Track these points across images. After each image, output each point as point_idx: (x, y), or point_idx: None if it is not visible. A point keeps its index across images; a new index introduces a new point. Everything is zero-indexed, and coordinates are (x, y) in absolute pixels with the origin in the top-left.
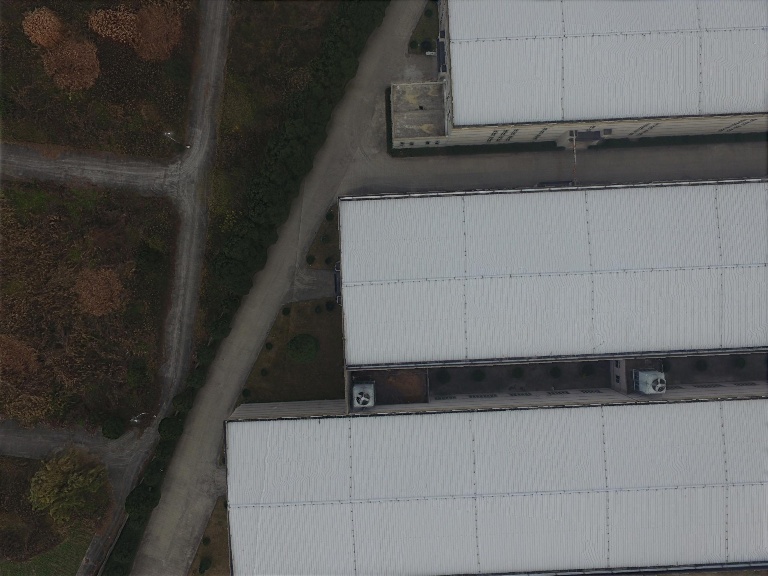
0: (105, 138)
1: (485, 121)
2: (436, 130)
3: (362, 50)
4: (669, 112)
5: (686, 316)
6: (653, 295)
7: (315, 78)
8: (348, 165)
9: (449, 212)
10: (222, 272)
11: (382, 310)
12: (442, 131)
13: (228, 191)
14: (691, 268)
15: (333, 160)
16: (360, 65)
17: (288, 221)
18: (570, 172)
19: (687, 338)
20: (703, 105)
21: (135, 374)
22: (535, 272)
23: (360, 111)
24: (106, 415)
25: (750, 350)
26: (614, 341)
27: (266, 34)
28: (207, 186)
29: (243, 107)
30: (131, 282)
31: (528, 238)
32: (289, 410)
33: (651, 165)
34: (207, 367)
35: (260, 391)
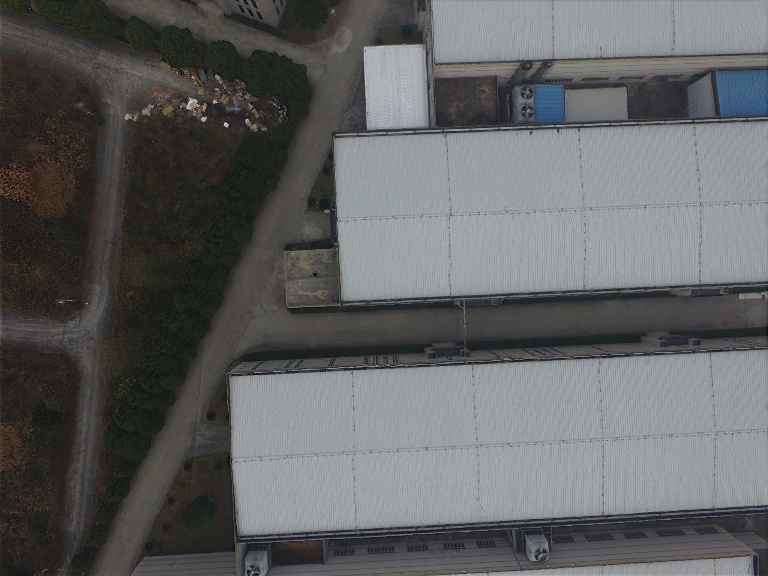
0: (1, 296)
1: (374, 297)
2: (330, 296)
3: (261, 207)
4: (554, 287)
5: (567, 489)
6: (535, 470)
7: (207, 248)
8: (248, 322)
9: (338, 387)
10: (114, 445)
11: (272, 484)
12: (336, 297)
13: (122, 358)
14: (573, 441)
15: (233, 317)
16: (259, 222)
17: (188, 377)
18: (468, 328)
19: (568, 509)
20: (591, 275)
21: (35, 533)
22: (422, 446)
23: (259, 268)
24: (8, 571)
25: (631, 517)
26: (496, 516)
27: (163, 191)
28: (106, 343)
29: (142, 263)
30: (30, 441)
31: (416, 413)
32: (186, 573)
33: (547, 321)
34: (109, 522)
35: (163, 544)
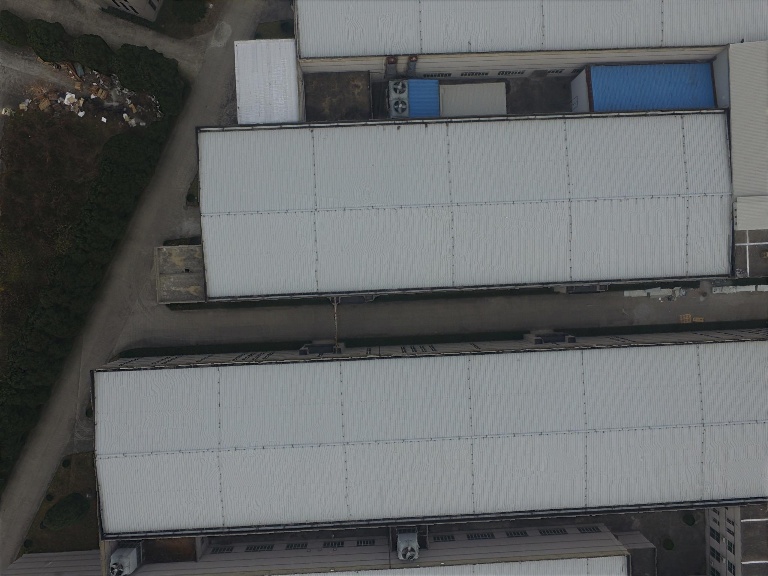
0: None
1: (240, 293)
2: None
3: (139, 202)
4: (423, 284)
5: (434, 487)
6: (401, 468)
7: (75, 243)
8: (127, 318)
9: (204, 383)
10: None
11: (137, 481)
12: None
13: None
14: (442, 439)
15: (112, 313)
16: (138, 217)
17: (67, 374)
18: (349, 325)
19: (436, 508)
20: (464, 271)
21: None
22: (288, 444)
23: (138, 264)
24: None
25: (502, 515)
26: (361, 514)
27: (40, 186)
28: None
29: None
30: None
31: (282, 409)
32: (58, 570)
33: (429, 318)
34: None
35: (42, 541)
